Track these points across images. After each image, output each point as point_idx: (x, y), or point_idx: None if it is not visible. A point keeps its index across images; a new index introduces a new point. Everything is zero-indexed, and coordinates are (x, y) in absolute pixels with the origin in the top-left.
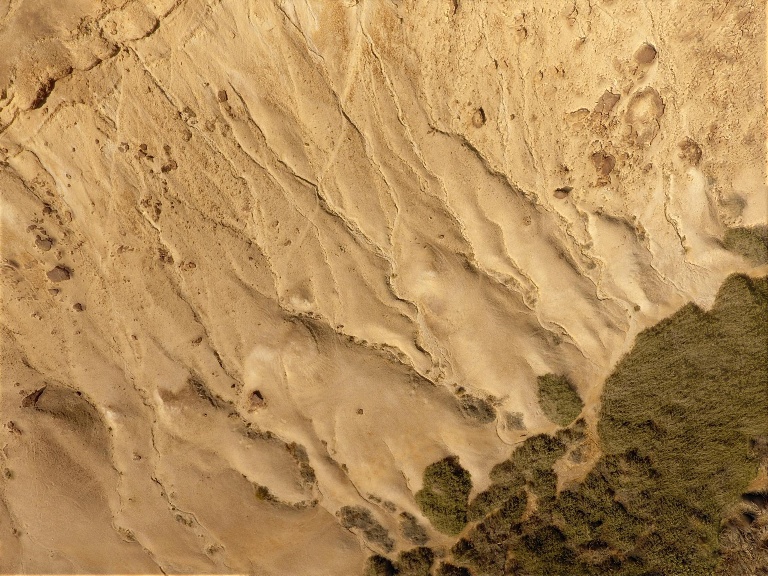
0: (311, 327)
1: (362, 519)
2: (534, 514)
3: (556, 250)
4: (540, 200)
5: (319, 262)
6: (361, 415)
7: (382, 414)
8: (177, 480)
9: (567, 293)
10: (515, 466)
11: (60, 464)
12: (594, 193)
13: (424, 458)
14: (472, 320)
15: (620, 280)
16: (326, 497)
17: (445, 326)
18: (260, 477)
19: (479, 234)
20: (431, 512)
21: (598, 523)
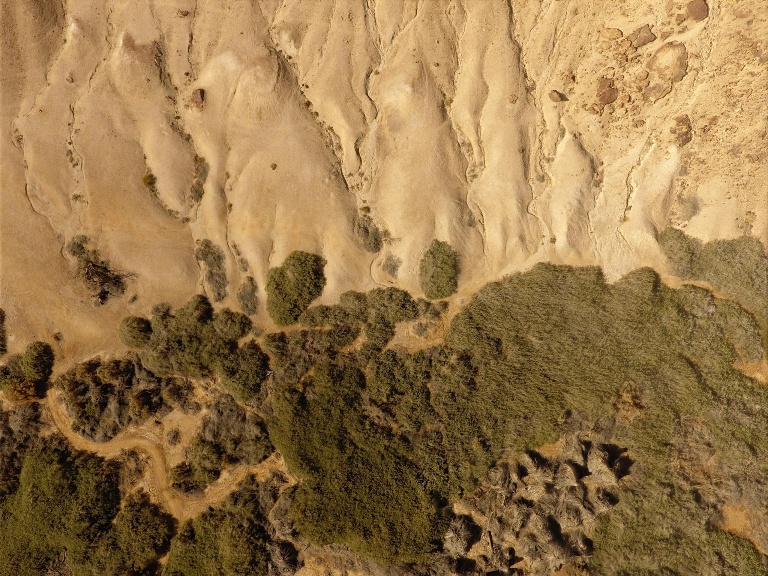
0: (282, 66)
1: (215, 259)
2: (355, 352)
3: (520, 142)
4: (536, 92)
5: (324, 14)
6: (272, 170)
7: (290, 181)
8: (89, 121)
9: (505, 185)
10: (367, 300)
11: (5, 40)
12: (582, 116)
13: (298, 241)
14: (414, 153)
15: (555, 206)
16: (198, 222)
17: (389, 145)
18: (157, 166)
19: (468, 84)
20: (273, 288)
21: (401, 393)
